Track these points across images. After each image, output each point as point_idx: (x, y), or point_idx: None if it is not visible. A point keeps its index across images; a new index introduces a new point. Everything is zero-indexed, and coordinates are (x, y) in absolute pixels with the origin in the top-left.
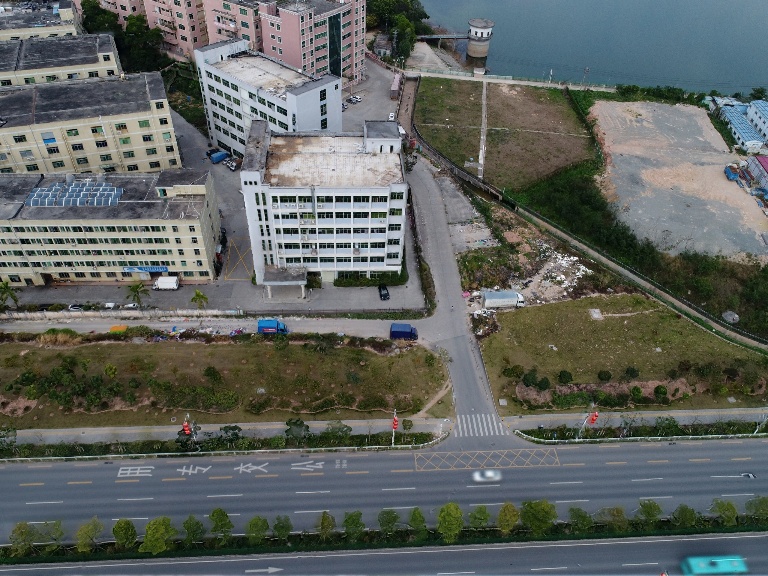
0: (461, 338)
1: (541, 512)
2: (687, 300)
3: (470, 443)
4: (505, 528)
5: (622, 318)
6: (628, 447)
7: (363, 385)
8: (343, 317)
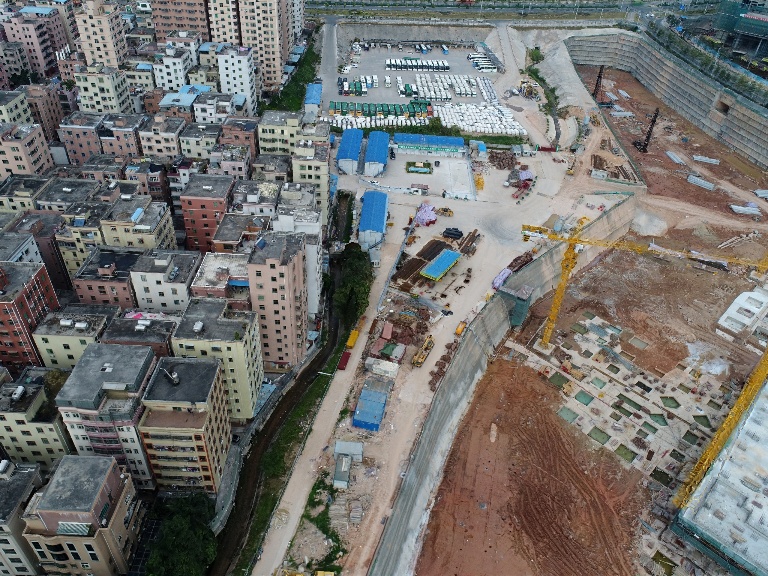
0: None
1: None
2: None
3: None
4: None
5: None
6: None
7: None
8: None
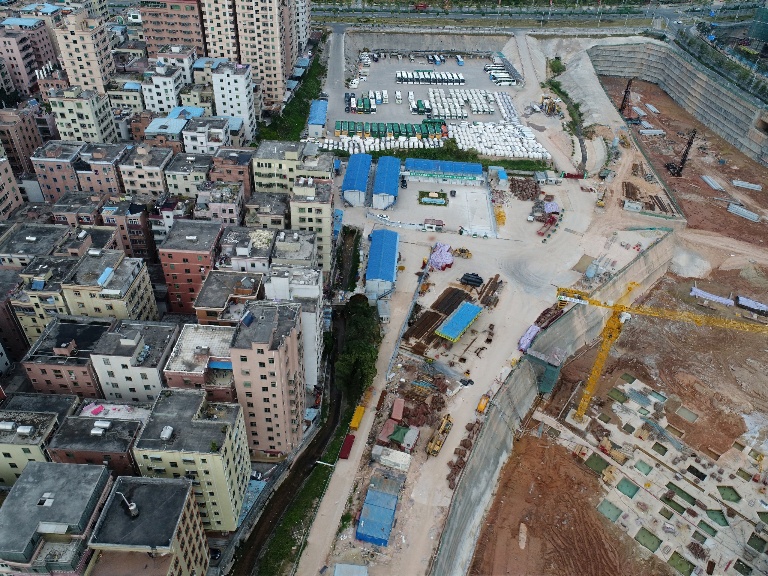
0: None
1: None
2: None
3: None
4: (362, 3)
5: None
6: (401, 7)
7: None
8: None
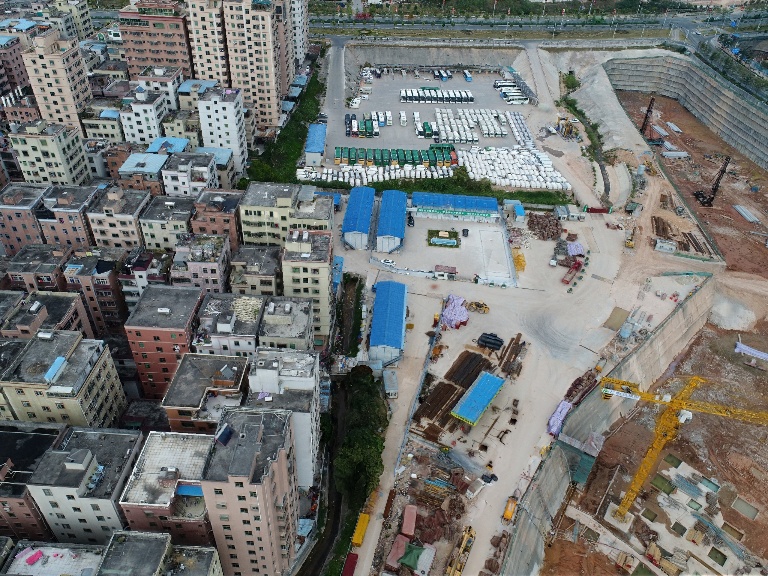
0: (359, 8)
1: (372, 7)
2: (438, 4)
3: (358, 16)
4: None
5: (414, 6)
6: None
7: (327, 3)
8: (320, 4)
